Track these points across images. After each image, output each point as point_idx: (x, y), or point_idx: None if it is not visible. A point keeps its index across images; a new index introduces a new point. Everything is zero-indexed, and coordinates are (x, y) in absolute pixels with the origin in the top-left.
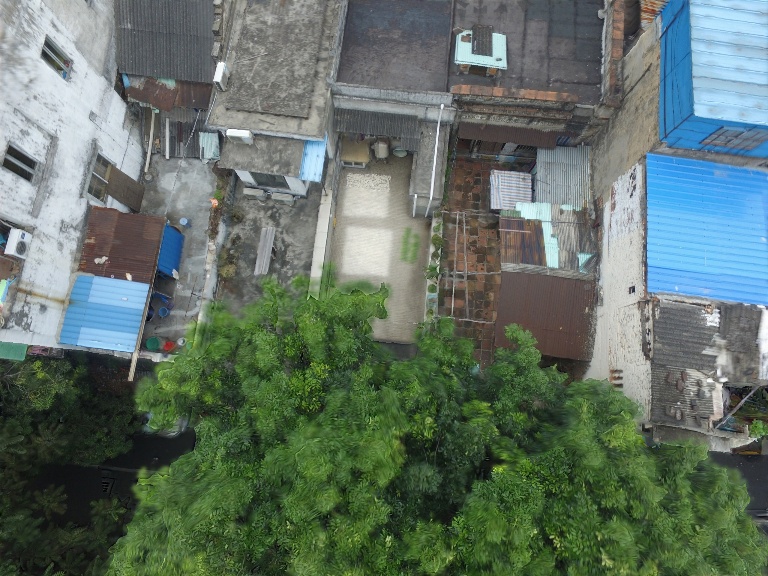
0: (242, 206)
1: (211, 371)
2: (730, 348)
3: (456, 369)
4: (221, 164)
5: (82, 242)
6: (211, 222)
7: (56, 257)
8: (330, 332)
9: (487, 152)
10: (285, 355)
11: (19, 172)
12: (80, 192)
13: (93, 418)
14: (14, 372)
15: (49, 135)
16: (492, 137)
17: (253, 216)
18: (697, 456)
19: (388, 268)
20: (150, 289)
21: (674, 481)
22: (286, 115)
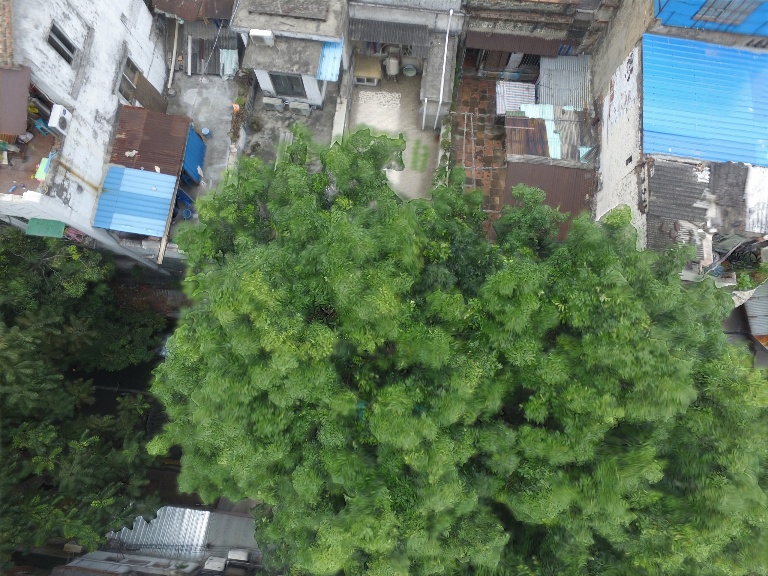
0: (261, 117)
1: (245, 207)
2: (719, 202)
3: (467, 220)
4: (244, 64)
5: (114, 137)
6: (233, 125)
7: (91, 144)
8: (354, 168)
9: (492, 69)
10: (313, 190)
11: (61, 53)
12: (112, 88)
13: (117, 328)
14: (50, 256)
15: (86, 25)
16: (498, 46)
17: (271, 126)
18: (686, 255)
19: (399, 177)
20: (177, 181)
21: (666, 280)
22: (305, 17)
